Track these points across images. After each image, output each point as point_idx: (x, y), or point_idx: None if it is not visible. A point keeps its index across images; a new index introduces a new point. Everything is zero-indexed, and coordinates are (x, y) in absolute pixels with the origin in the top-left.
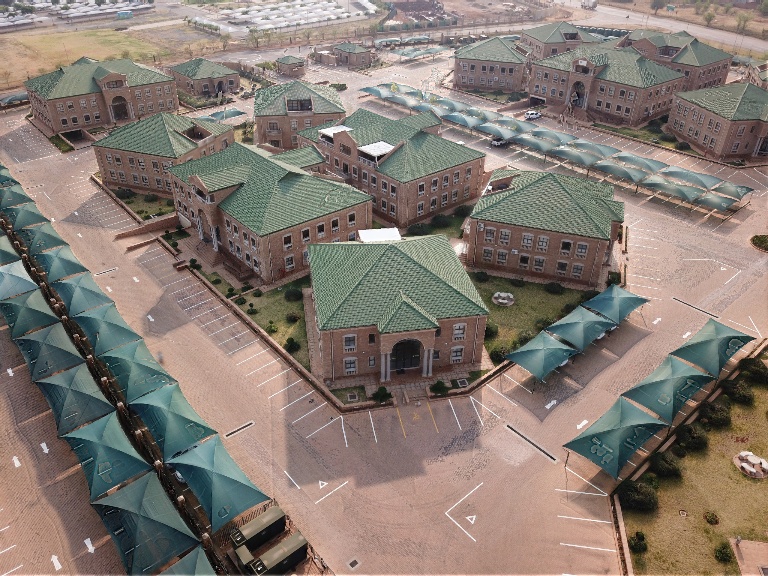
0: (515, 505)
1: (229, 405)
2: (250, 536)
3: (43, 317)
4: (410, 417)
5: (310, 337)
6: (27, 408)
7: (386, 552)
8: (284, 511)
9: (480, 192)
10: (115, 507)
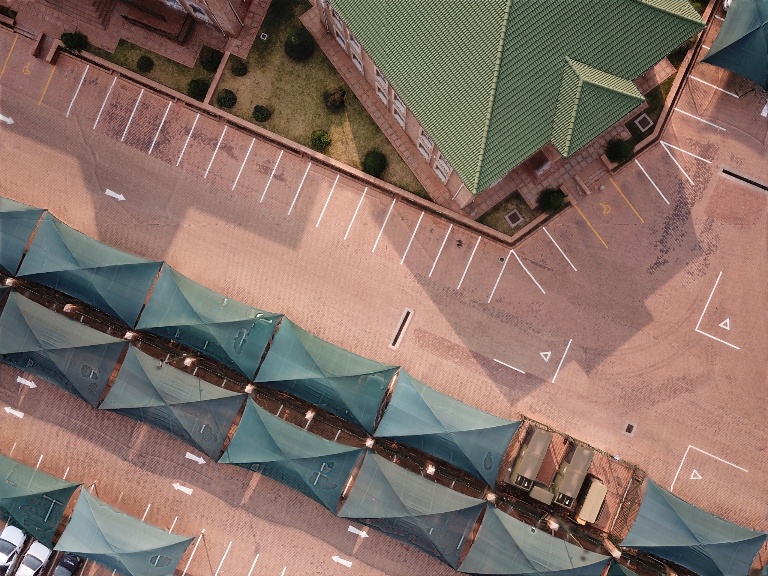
0: (766, 286)
1: (360, 299)
2: (535, 476)
3: None
4: (599, 213)
5: (387, 129)
6: (113, 421)
7: (655, 402)
8: (527, 408)
9: None
10: None
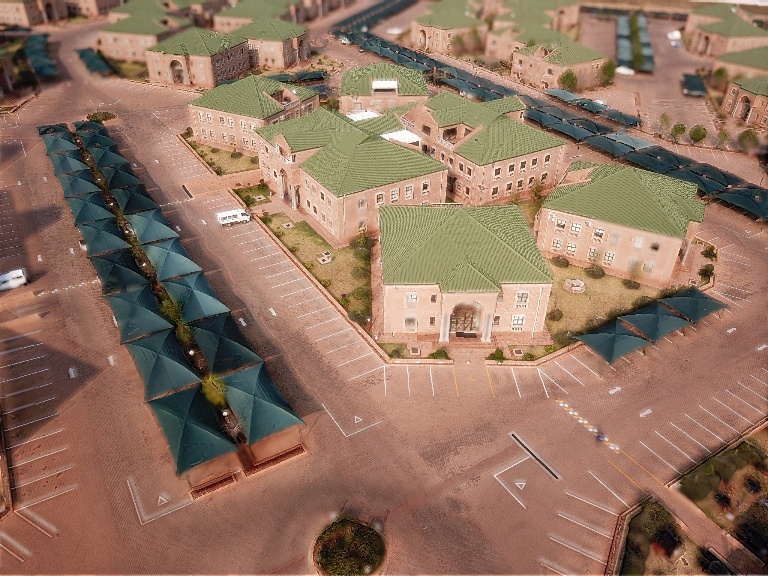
0: None
1: None
2: None
3: None
4: None
5: None
6: None
7: None
8: None
9: None
10: None
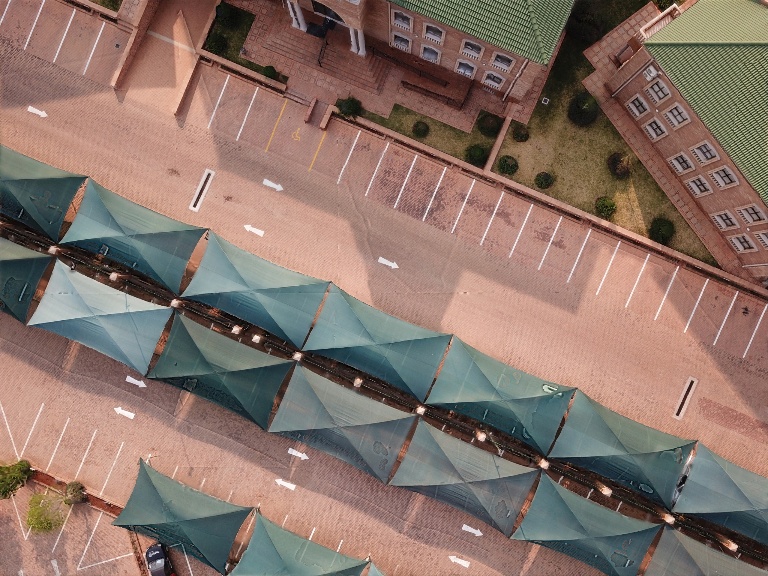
0: None
1: (642, 368)
2: None
3: (267, 374)
4: None
5: (673, 196)
6: (388, 493)
7: None
8: None
9: None
10: None
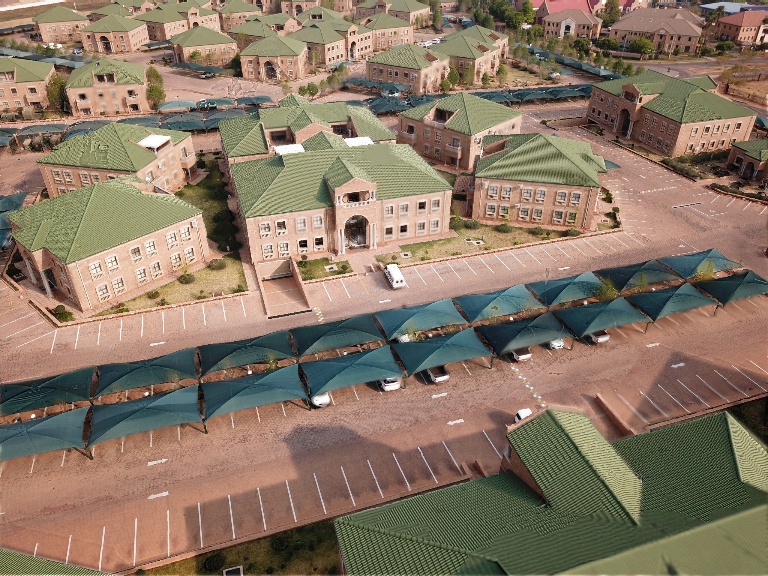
0: None
1: None
2: None
3: None
4: None
5: None
6: None
7: None
8: None
9: (252, 260)
10: (102, 120)
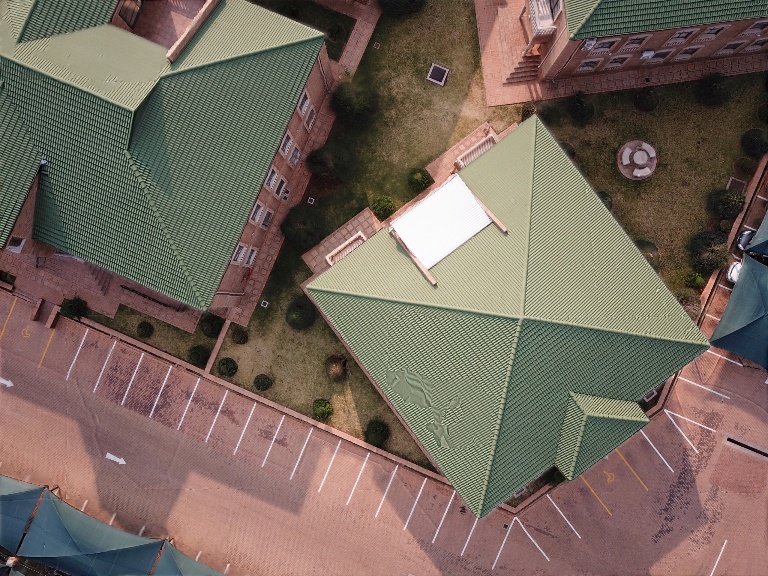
0: None
1: (363, 565)
2: None
3: None
4: (603, 481)
5: None
6: None
7: None
8: None
9: None
10: None
